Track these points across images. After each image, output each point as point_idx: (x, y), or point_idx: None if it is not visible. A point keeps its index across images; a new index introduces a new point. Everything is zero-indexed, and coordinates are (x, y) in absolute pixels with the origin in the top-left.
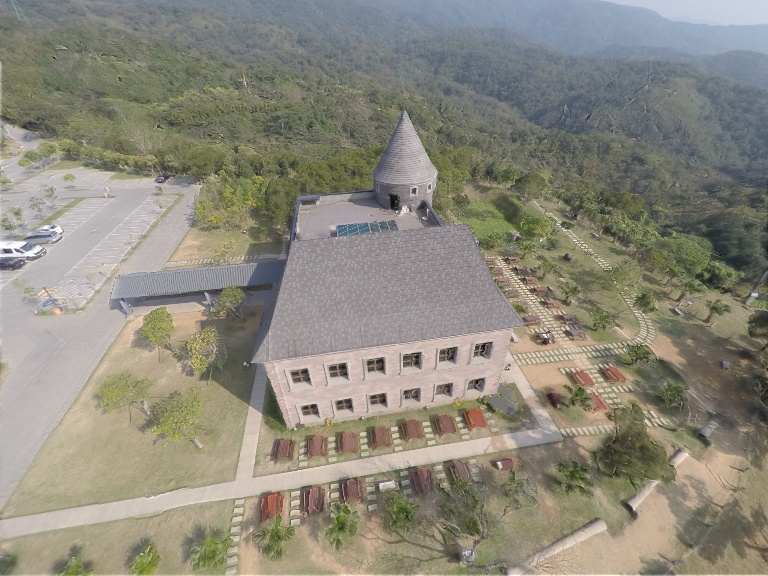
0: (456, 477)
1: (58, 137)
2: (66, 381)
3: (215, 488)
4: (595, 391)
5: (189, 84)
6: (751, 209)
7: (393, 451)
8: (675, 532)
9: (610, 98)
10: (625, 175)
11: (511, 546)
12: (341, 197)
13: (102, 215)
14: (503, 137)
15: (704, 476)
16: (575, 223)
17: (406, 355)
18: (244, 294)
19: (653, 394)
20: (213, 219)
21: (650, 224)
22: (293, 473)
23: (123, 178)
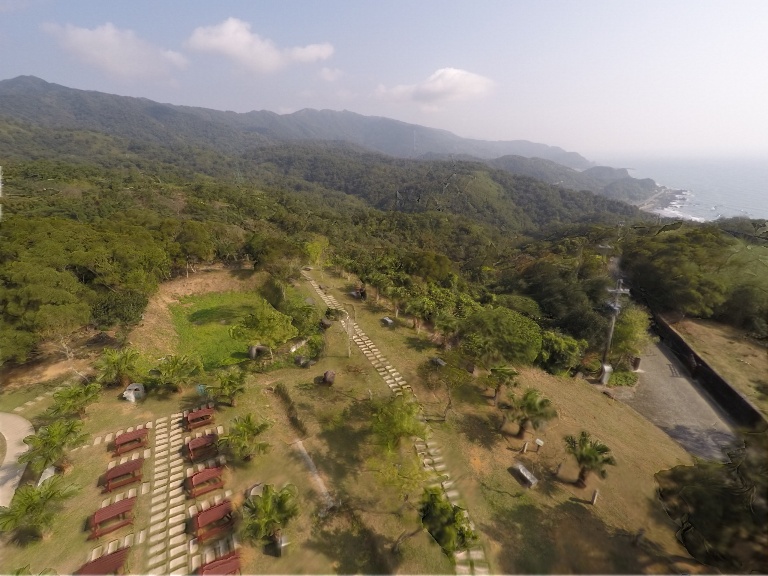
0: None
1: None
2: None
3: None
4: None
5: None
6: (559, 256)
7: None
8: None
9: (431, 184)
10: (457, 244)
11: None
12: None
13: None
14: (345, 221)
15: None
16: (362, 306)
17: None
18: None
19: None
20: None
21: (465, 289)
22: None
23: None
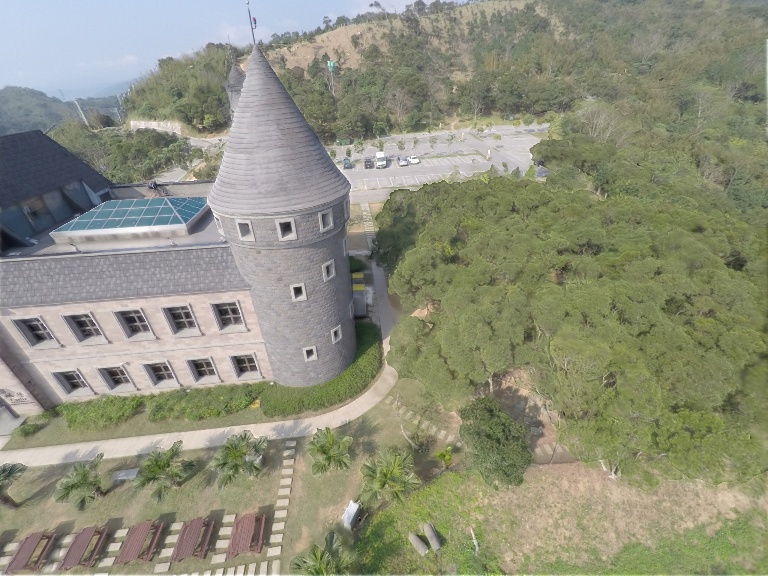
0: None
1: (560, 109)
2: None
3: None
4: None
5: None
6: None
7: None
8: None
9: None
10: None
11: None
12: None
13: (449, 166)
14: None
15: None
16: None
17: None
18: None
19: None
20: None
21: None
22: None
23: None
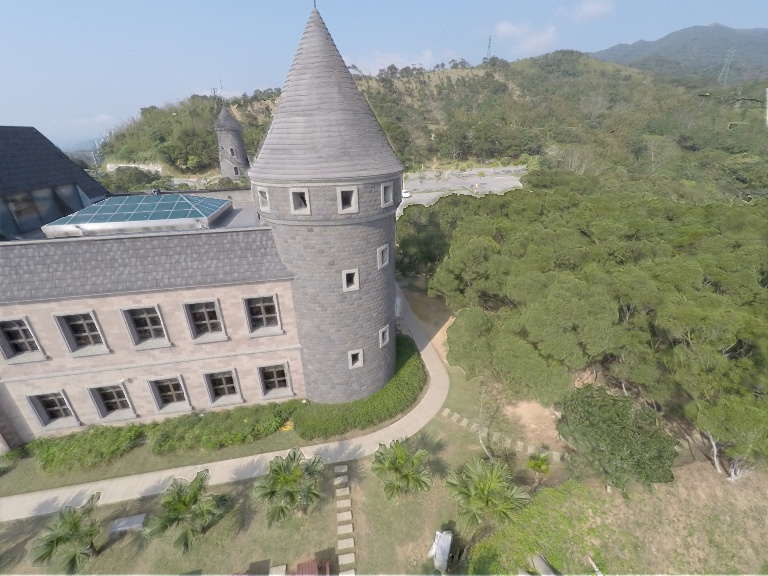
0: None
1: (534, 152)
2: None
3: None
4: None
5: None
6: None
7: None
8: None
9: None
10: None
11: None
12: None
13: None
14: None
15: None
16: None
17: None
18: None
19: None
20: None
21: None
22: None
23: None
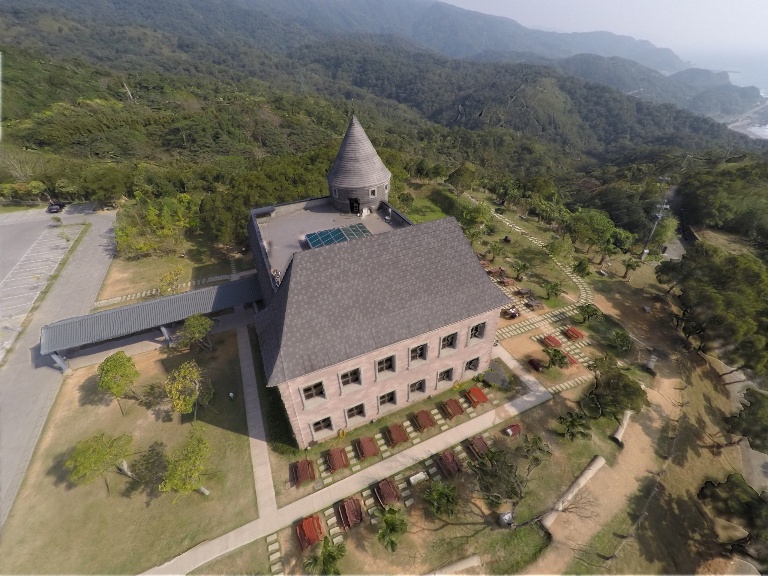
0: (477, 453)
1: None
2: (1, 464)
3: (239, 532)
4: (564, 350)
5: (57, 97)
6: (627, 183)
7: (412, 444)
8: (653, 450)
9: (495, 97)
10: (519, 164)
11: (538, 500)
12: (296, 206)
13: None
14: (411, 137)
15: (659, 400)
16: None
17: (412, 349)
18: (212, 321)
19: (605, 343)
20: (142, 246)
21: (560, 203)
22: (320, 492)
23: (0, 212)
